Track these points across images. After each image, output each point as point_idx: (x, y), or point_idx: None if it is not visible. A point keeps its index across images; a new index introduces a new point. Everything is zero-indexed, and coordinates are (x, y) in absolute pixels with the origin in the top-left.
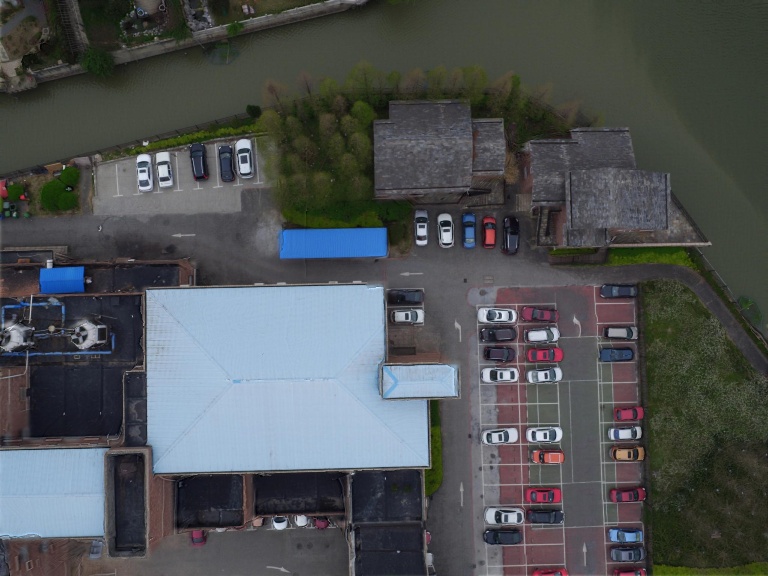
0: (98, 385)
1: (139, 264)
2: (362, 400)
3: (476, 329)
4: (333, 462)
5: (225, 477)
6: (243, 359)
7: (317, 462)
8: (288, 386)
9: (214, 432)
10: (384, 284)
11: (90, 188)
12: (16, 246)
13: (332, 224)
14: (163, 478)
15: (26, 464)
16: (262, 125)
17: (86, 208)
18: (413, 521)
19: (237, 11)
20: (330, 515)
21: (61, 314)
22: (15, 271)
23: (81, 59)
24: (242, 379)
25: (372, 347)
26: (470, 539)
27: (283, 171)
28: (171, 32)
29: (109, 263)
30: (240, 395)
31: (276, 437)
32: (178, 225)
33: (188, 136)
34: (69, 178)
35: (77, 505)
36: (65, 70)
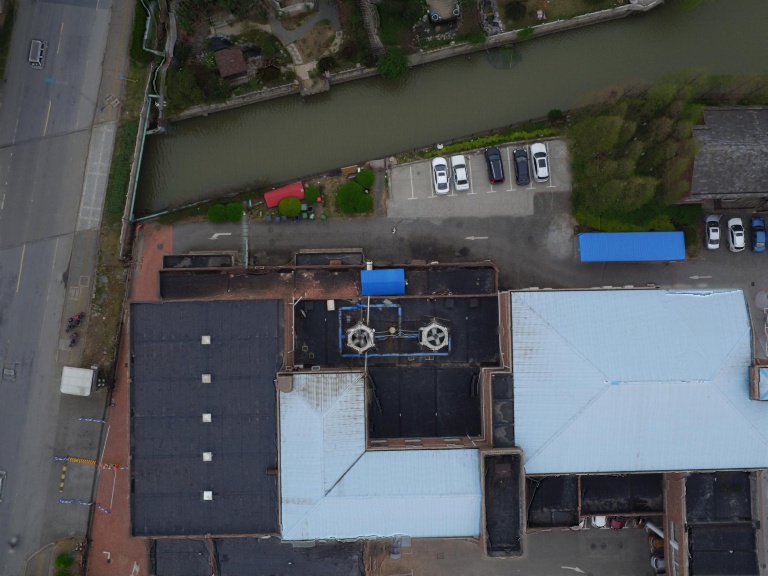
0: (432, 386)
1: (453, 266)
2: (733, 402)
3: (764, 332)
4: (697, 463)
5: (561, 478)
6: (618, 361)
7: (682, 463)
8: (664, 388)
9: (586, 433)
10: (674, 287)
11: (383, 191)
12: (311, 248)
13: (626, 228)
14: (531, 479)
15: (397, 465)
16: (556, 129)
17: (380, 210)
18: (743, 521)
19: (532, 16)
20: (645, 516)
21: (397, 316)
22: (330, 273)
23: (381, 63)
24: (620, 381)
25: (740, 349)
26: (760, 539)
27: (575, 175)
28: (466, 37)
29: (426, 265)
30: (617, 397)
31: (645, 438)
32: (471, 228)
33: (483, 140)
34: (367, 181)
35: (451, 505)
36: (356, 73)
